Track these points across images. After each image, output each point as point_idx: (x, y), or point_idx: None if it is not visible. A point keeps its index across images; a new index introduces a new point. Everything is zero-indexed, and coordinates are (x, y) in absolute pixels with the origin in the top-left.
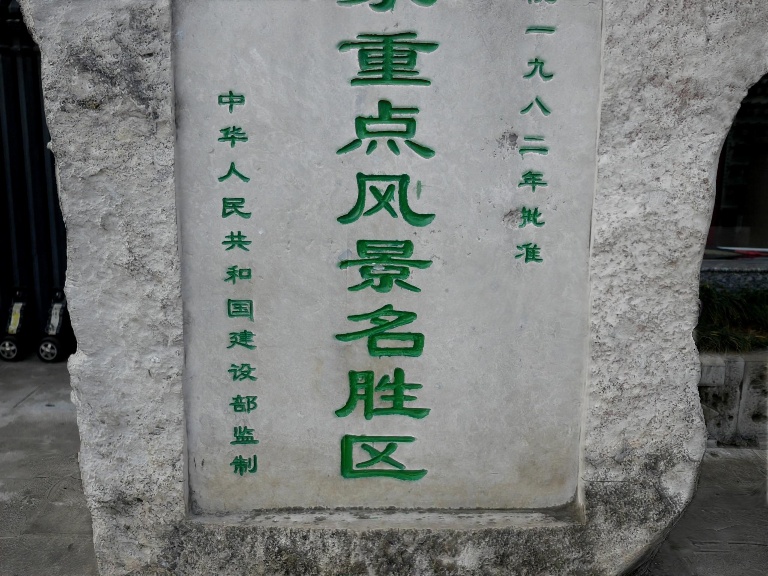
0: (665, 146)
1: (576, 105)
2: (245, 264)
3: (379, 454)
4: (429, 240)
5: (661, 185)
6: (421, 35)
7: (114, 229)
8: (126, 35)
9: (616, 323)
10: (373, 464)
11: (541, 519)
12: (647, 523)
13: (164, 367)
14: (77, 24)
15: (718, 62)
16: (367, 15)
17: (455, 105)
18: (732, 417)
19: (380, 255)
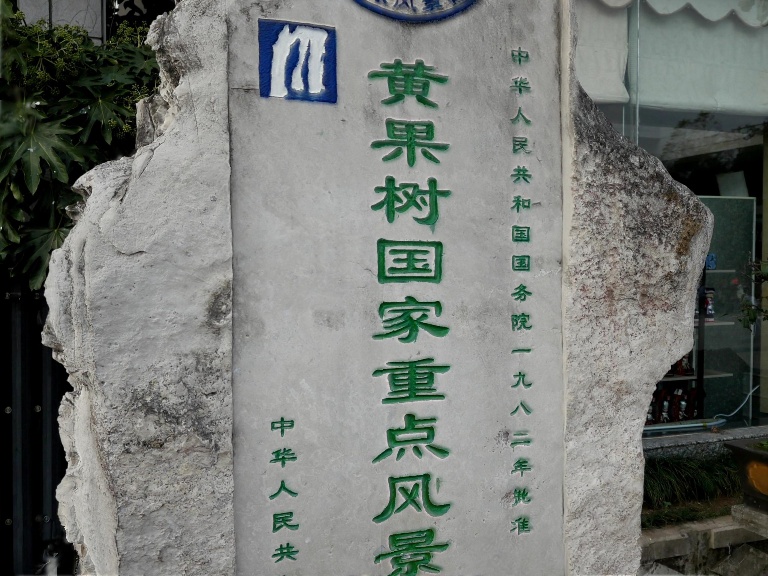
0: (609, 431)
1: (548, 405)
2: (292, 573)
3: None
4: (446, 527)
5: (609, 461)
6: (437, 360)
7: (171, 560)
8: (193, 378)
9: (586, 575)
10: None
11: None
12: None
13: None
14: (143, 369)
15: (639, 367)
16: (396, 346)
17: (463, 413)
18: None
19: (407, 546)
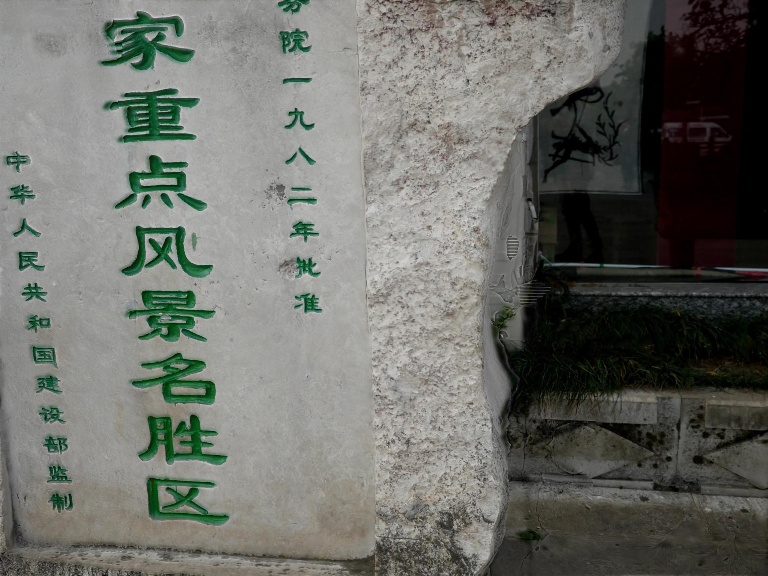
0: (434, 193)
1: (341, 153)
2: (44, 314)
3: (183, 498)
4: (209, 291)
5: (432, 234)
6: (182, 90)
7: None
8: None
9: (397, 376)
10: (178, 508)
11: (334, 572)
12: None
13: None
14: None
15: (480, 103)
16: (130, 74)
17: (221, 157)
18: (670, 457)
19: (166, 305)
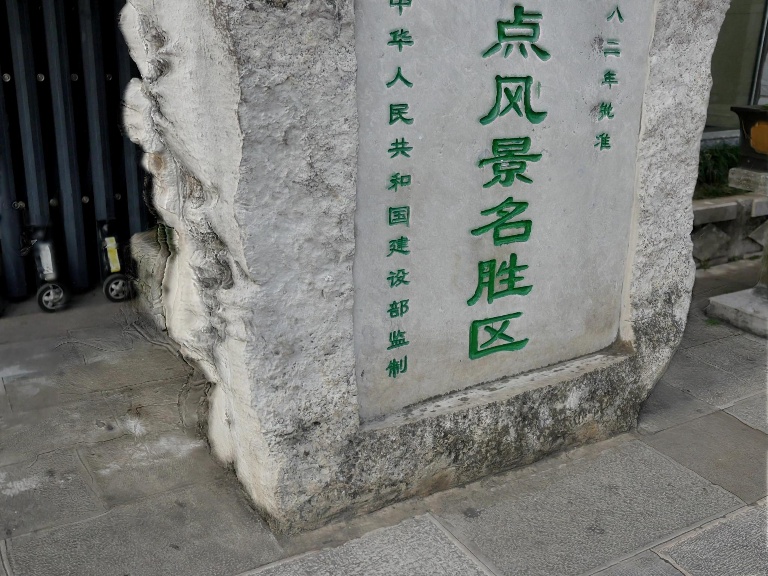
0: (687, 49)
1: (639, 14)
2: (406, 171)
3: (495, 333)
4: (542, 136)
5: (684, 81)
6: None
7: (295, 143)
8: None
9: (653, 194)
10: (492, 342)
11: (606, 359)
12: (669, 344)
13: (337, 285)
14: None
15: None
16: None
17: (567, 12)
18: None
19: (507, 152)
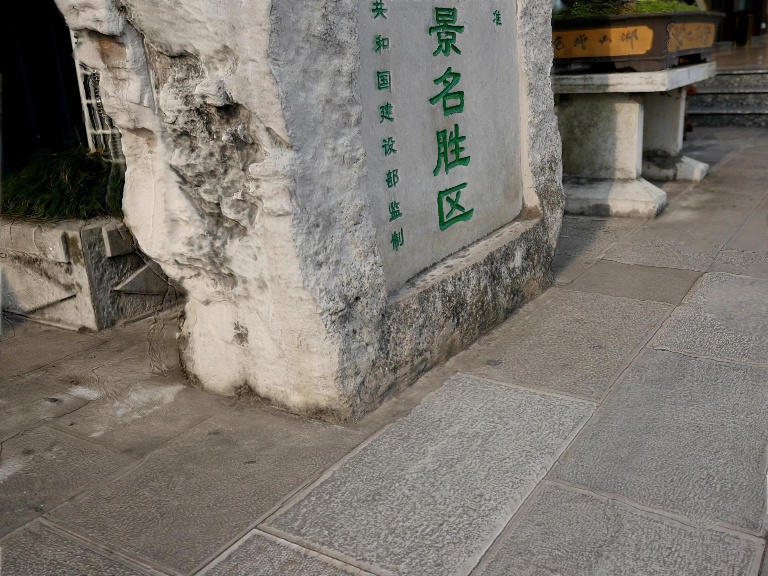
0: None
1: None
2: (386, 33)
3: None
4: (463, 7)
5: None
6: None
7: None
8: None
9: (531, 68)
10: (452, 213)
11: None
12: (560, 206)
13: (354, 150)
14: None
15: None
16: None
17: None
18: None
19: (444, 22)
